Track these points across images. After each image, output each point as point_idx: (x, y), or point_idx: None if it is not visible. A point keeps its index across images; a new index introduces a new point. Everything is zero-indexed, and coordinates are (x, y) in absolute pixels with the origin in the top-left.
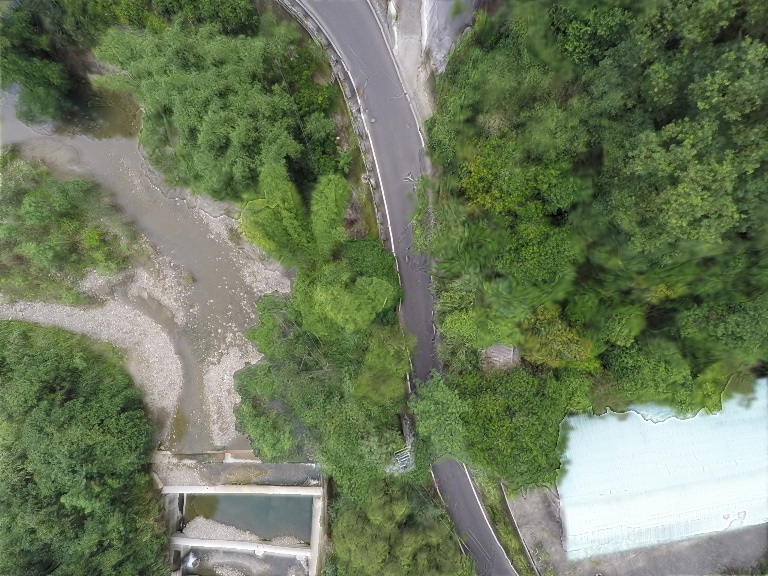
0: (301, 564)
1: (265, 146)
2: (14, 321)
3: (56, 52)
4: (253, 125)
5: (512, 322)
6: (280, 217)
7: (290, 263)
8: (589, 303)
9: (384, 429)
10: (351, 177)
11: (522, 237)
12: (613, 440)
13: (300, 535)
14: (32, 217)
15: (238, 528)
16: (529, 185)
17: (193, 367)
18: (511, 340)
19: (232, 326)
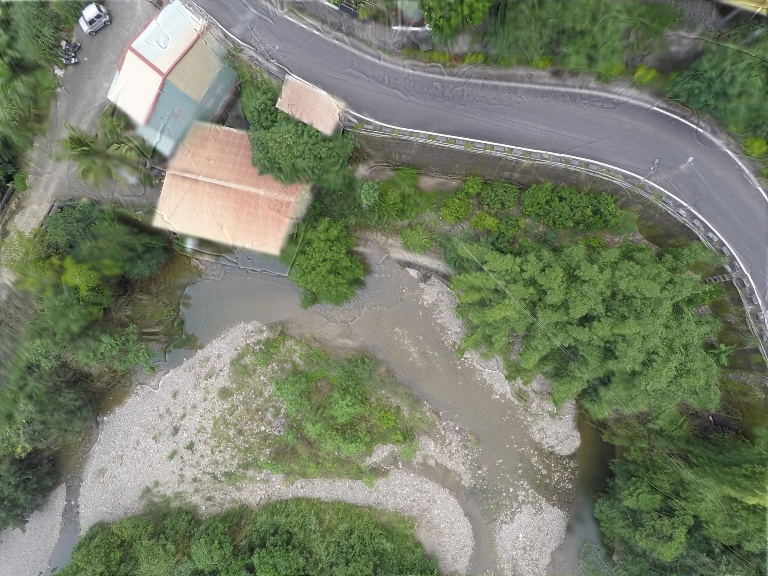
0: None
1: None
2: (299, 500)
3: None
4: None
5: None
6: None
7: None
8: None
9: None
10: (725, 366)
11: None
12: None
13: None
14: (345, 414)
15: None
16: None
17: (483, 527)
18: None
19: (524, 484)
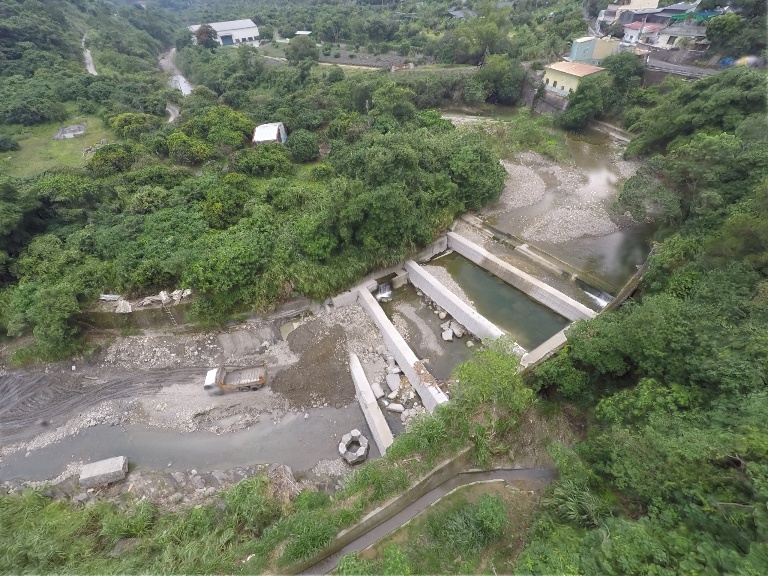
0: None
1: None
2: None
3: (610, 105)
4: None
5: None
6: None
7: None
8: None
9: None
10: None
11: None
12: None
13: (521, 342)
14: None
15: (466, 295)
16: None
17: None
18: None
19: None
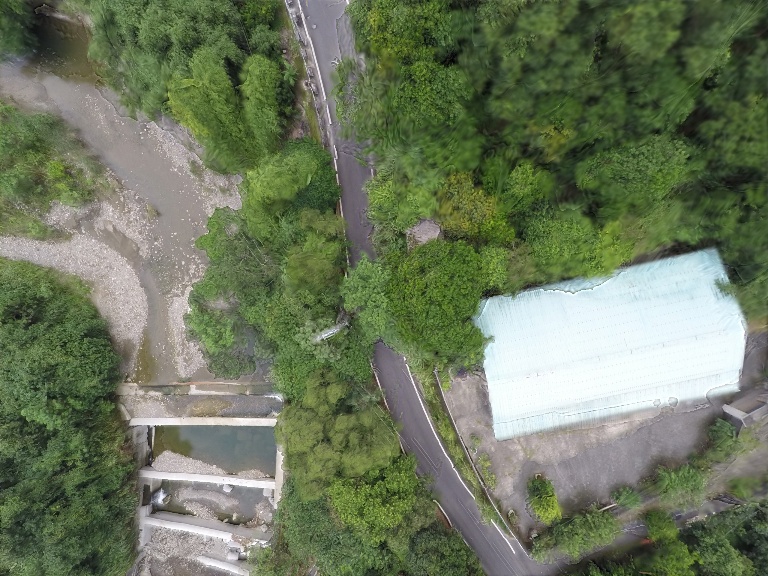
0: (269, 501)
1: (204, 47)
2: None
3: None
4: (191, 24)
5: (428, 191)
6: (207, 98)
7: (228, 160)
8: (496, 158)
9: (319, 321)
10: (298, 90)
11: (415, 74)
12: (542, 325)
13: (266, 469)
14: None
15: (205, 462)
16: (416, 14)
17: (158, 300)
18: (429, 211)
19: (195, 258)
